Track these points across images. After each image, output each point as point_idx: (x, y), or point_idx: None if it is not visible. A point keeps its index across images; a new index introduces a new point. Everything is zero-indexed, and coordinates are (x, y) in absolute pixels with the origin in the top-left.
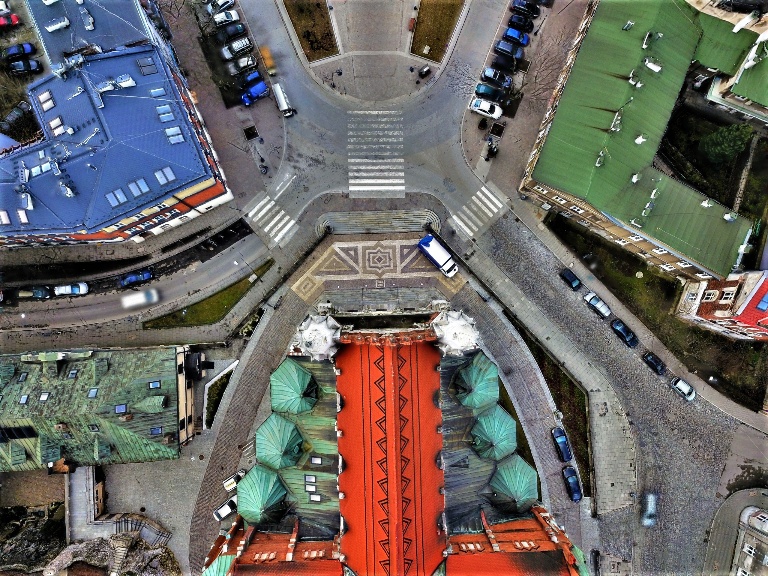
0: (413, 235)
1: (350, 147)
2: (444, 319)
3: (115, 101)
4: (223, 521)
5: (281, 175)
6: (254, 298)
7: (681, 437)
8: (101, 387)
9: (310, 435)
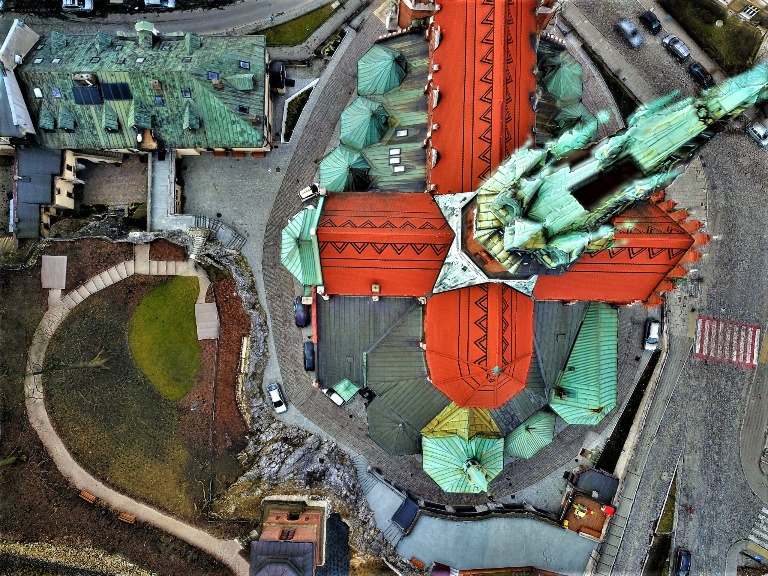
0: None
1: None
2: None
3: None
4: None
5: None
6: (336, 24)
7: (754, 181)
8: (195, 56)
9: (397, 110)
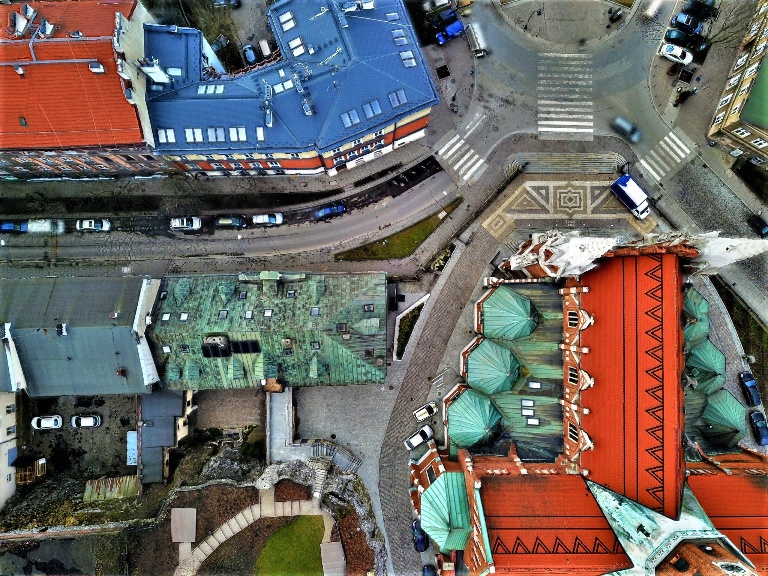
0: (603, 177)
1: (540, 89)
2: (705, 237)
3: (356, 22)
4: (412, 451)
5: (471, 114)
6: (443, 234)
7: None
8: (322, 306)
9: (528, 360)
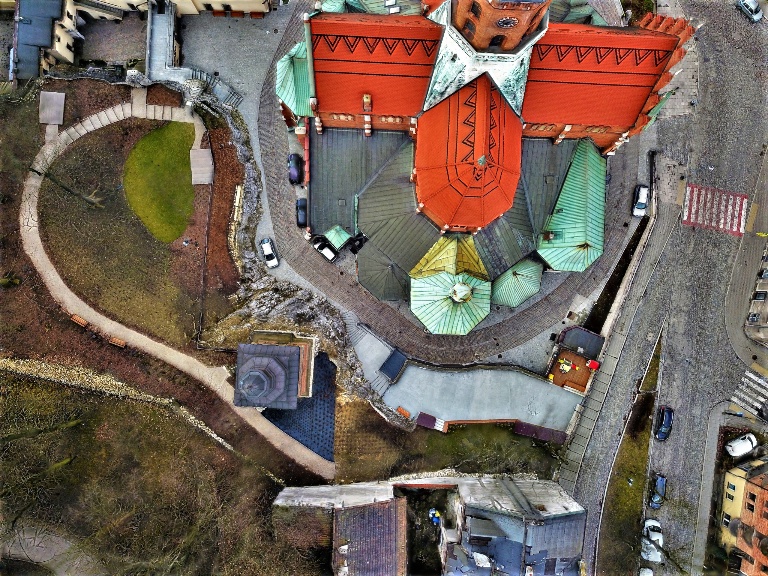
0: None
1: None
2: None
3: None
4: None
5: None
6: None
7: (745, 56)
8: None
9: None
